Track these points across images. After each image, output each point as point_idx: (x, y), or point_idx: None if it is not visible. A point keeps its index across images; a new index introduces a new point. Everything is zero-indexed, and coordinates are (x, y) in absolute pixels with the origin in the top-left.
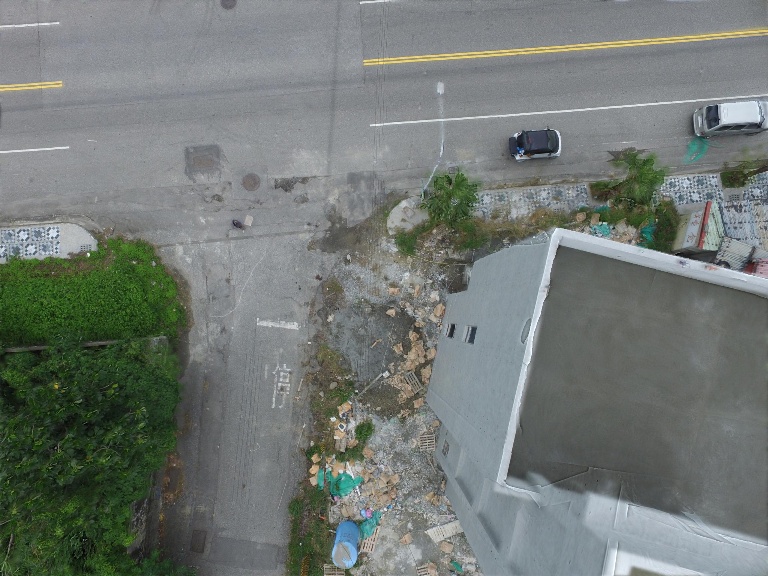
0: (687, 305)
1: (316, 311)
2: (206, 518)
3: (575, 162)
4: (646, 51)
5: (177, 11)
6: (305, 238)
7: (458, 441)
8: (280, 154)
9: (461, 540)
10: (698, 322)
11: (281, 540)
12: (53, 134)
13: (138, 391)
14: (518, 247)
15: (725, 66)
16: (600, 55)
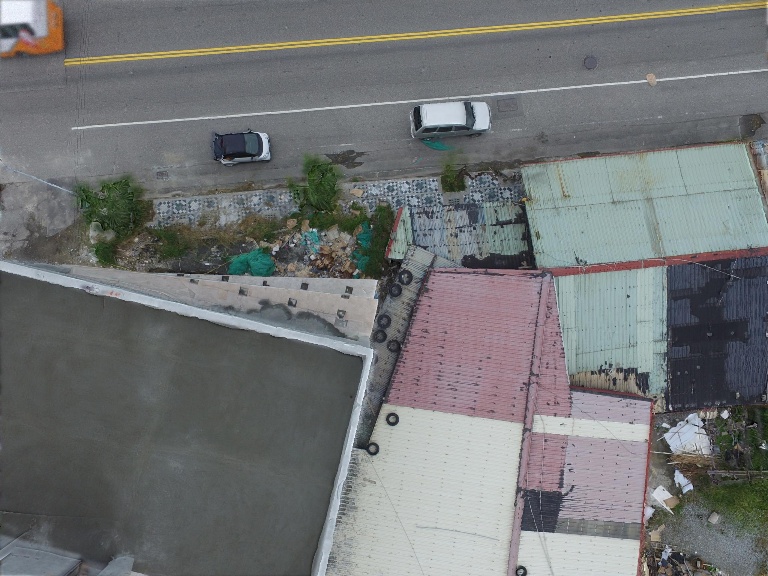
0: (140, 331)
1: None
2: None
3: (290, 166)
4: (365, 49)
5: None
6: (0, 248)
7: None
8: None
9: None
10: (151, 349)
11: None
12: None
13: None
14: None
15: (448, 64)
16: (316, 53)
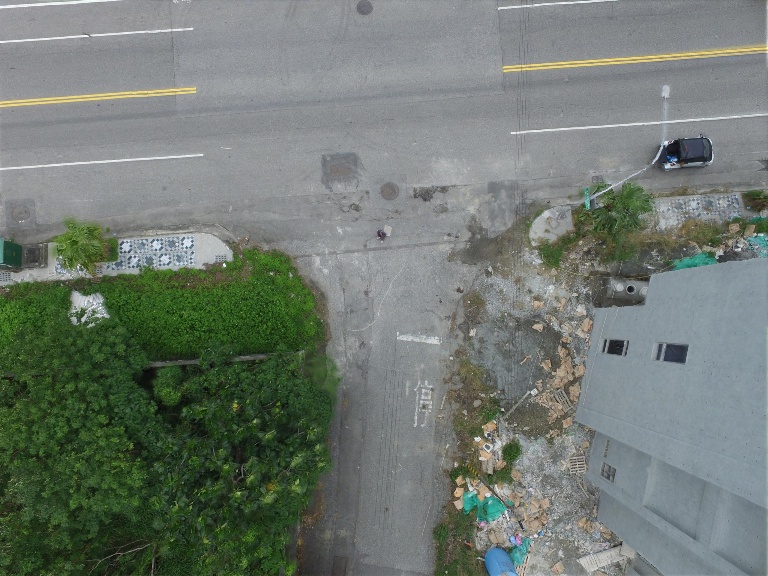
0: None
1: (457, 325)
2: (347, 543)
3: (724, 171)
4: None
5: (313, 17)
6: (445, 249)
7: (685, 468)
8: (419, 162)
9: (615, 570)
10: None
11: (426, 568)
12: (187, 141)
13: (298, 409)
14: (767, 260)
15: None
16: (748, 61)
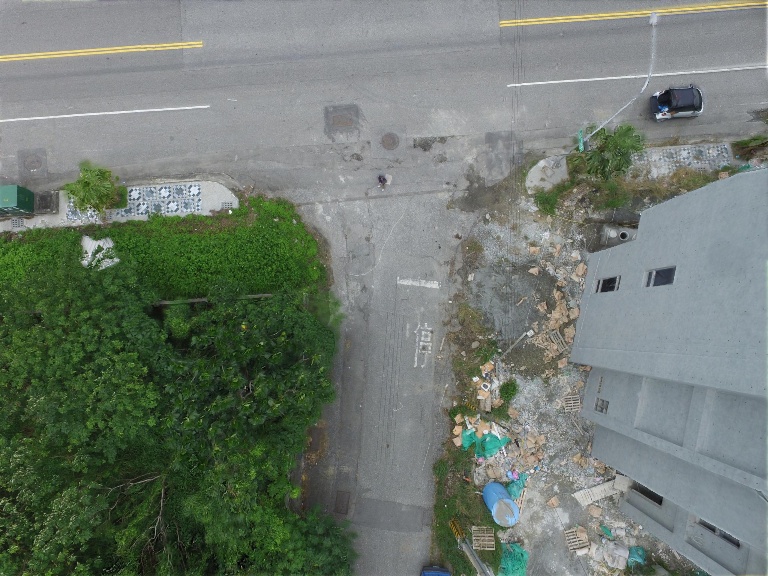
0: None
1: (456, 270)
2: (350, 478)
3: (714, 122)
4: None
5: None
6: (444, 197)
7: (672, 377)
8: (418, 114)
9: (609, 504)
10: None
11: (426, 502)
12: (194, 93)
13: (303, 340)
14: (749, 173)
15: None
16: (737, 16)
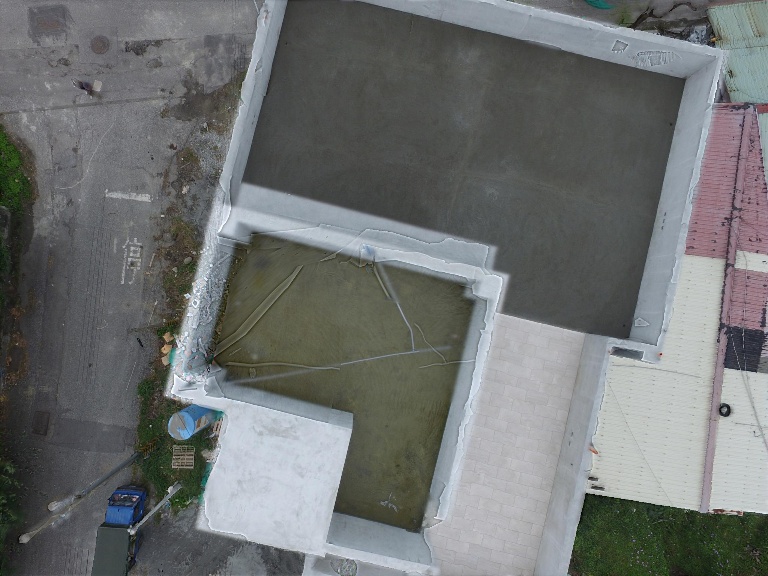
0: (449, 55)
1: (170, 183)
2: (49, 399)
3: None
4: None
5: None
6: (158, 105)
7: None
8: (131, 15)
9: None
10: (461, 74)
11: (129, 422)
12: None
13: None
14: None
15: None
16: None
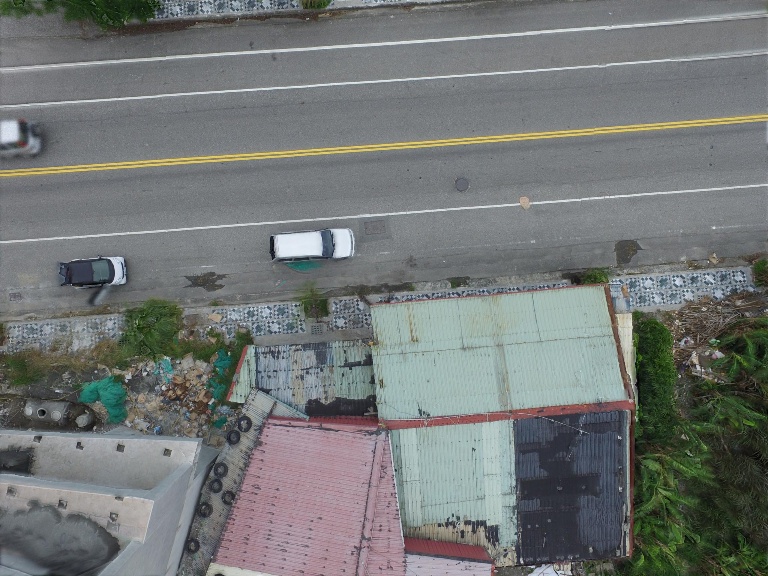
0: None
1: None
2: None
3: (148, 288)
4: (228, 168)
5: None
6: None
7: None
8: None
9: None
10: None
11: None
12: None
13: None
14: None
15: (314, 185)
16: (177, 172)
